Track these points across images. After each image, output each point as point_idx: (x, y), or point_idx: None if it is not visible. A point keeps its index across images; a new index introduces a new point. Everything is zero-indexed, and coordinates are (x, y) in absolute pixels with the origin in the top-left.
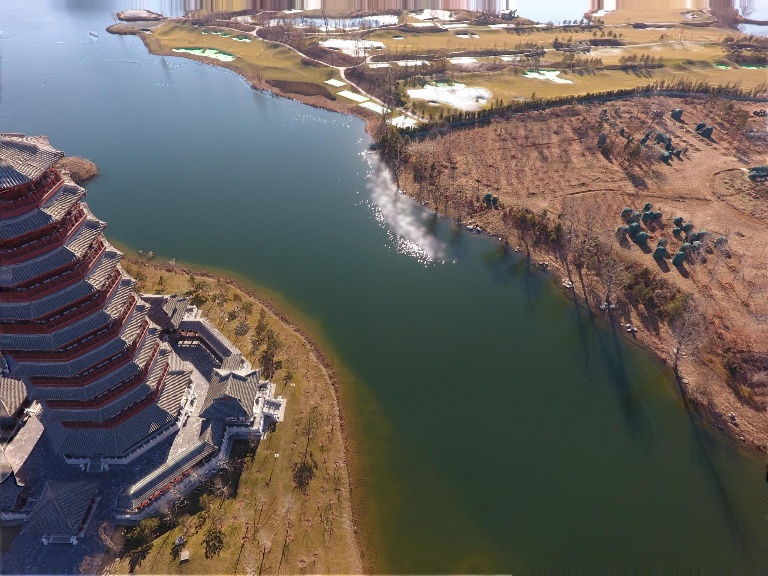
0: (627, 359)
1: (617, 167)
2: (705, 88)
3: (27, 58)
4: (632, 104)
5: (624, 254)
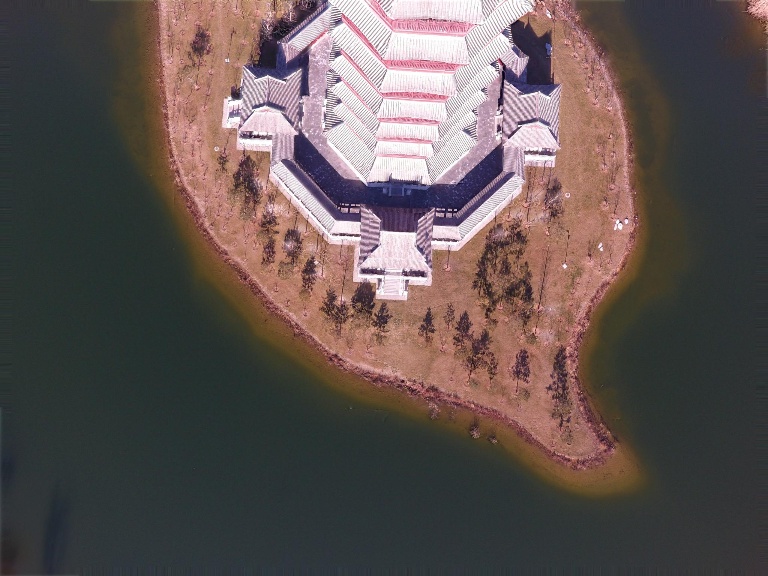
0: None
1: None
2: None
3: None
4: None
5: None
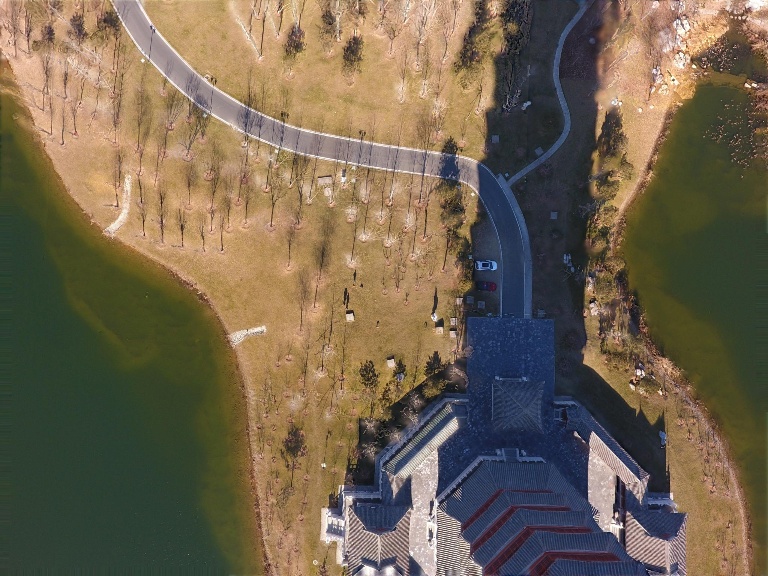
0: None
1: None
2: None
3: None
4: None
5: None
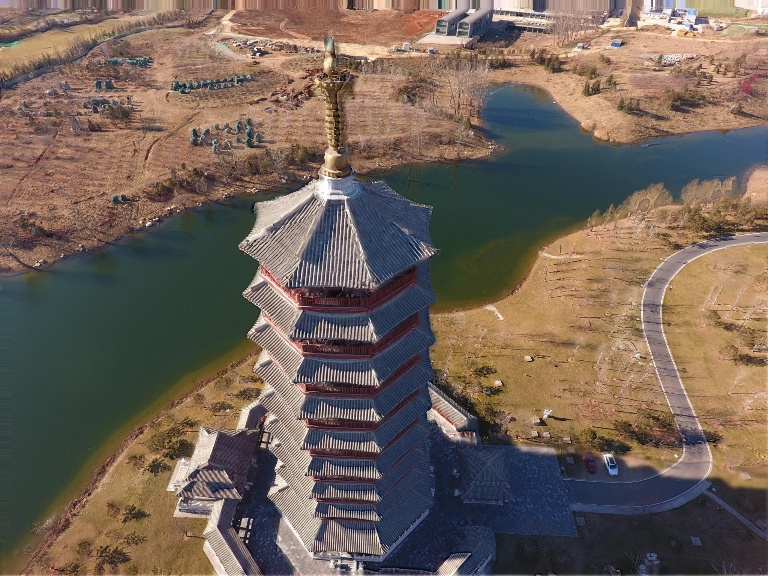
0: None
1: (124, 130)
2: (39, 63)
3: None
4: (18, 97)
5: (241, 156)
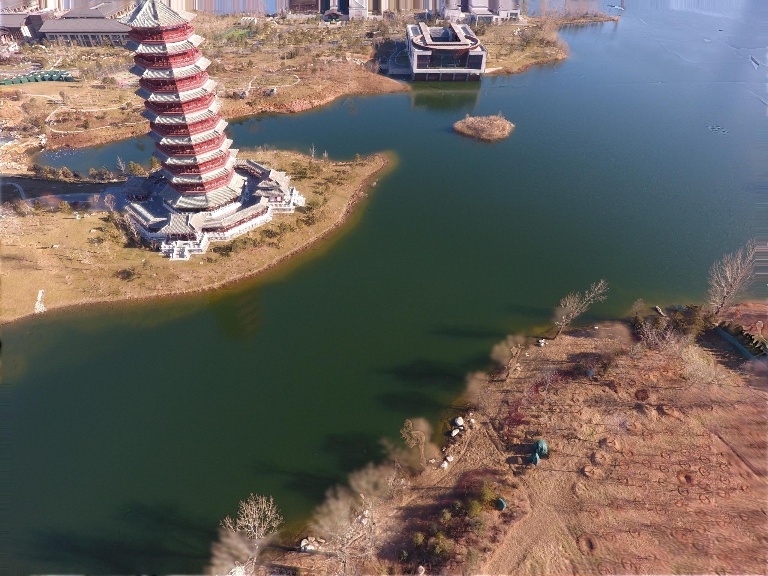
0: None
1: None
2: None
3: (702, 64)
4: None
5: None
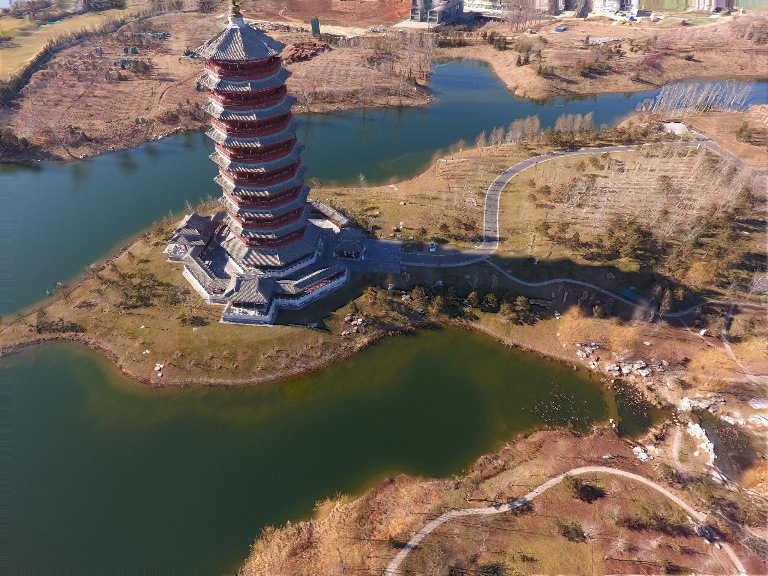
0: (299, 119)
1: (145, 80)
2: (79, 34)
3: None
4: (63, 58)
5: None
